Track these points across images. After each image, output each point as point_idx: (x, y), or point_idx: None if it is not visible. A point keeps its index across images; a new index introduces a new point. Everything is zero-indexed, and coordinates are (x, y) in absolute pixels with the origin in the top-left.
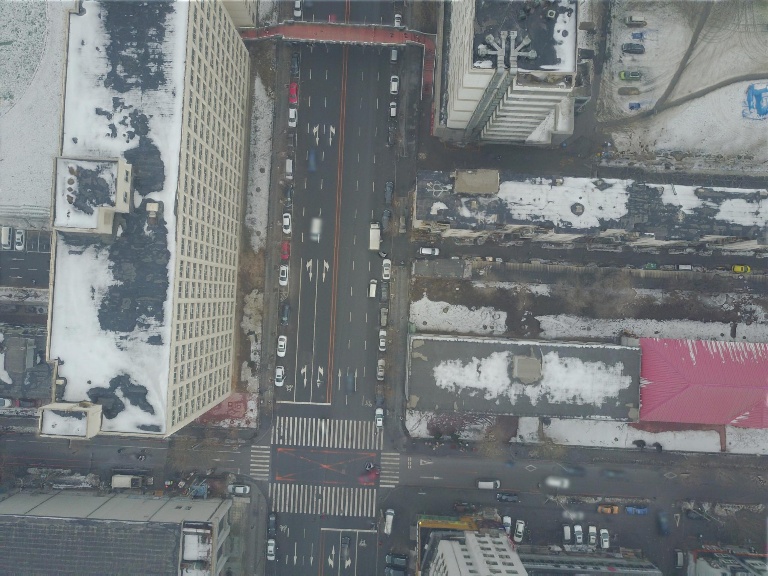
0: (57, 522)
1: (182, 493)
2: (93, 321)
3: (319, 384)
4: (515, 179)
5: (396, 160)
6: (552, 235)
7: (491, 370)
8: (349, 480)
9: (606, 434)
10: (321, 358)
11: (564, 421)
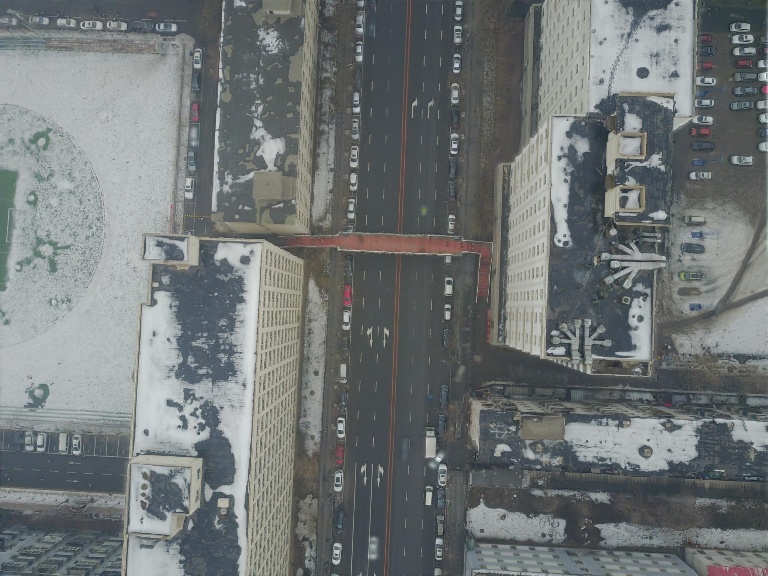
0: None
1: None
2: None
3: None
4: (580, 420)
5: (451, 362)
6: None
7: None
8: None
9: None
10: (376, 566)
11: None
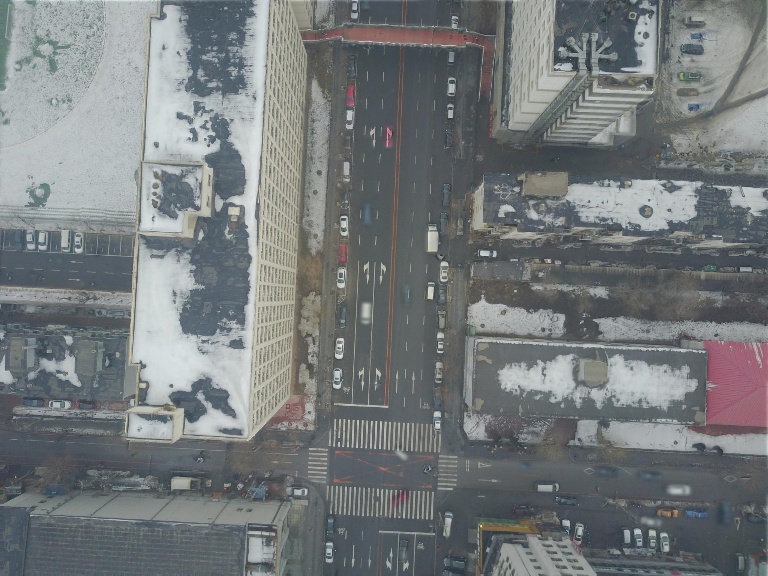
0: (123, 524)
1: (241, 495)
2: (175, 325)
3: (376, 386)
4: (583, 181)
5: (453, 162)
6: (616, 237)
7: (556, 373)
8: (407, 483)
9: (666, 437)
10: (379, 360)
11: (623, 424)
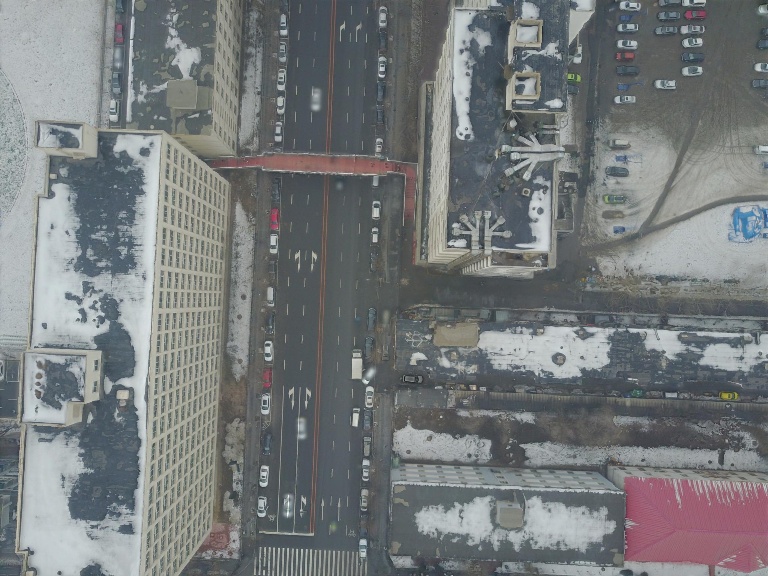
0: None
1: None
2: (63, 510)
3: (302, 514)
4: (495, 328)
5: (378, 286)
6: None
7: (473, 516)
8: None
9: None
10: (304, 488)
11: None
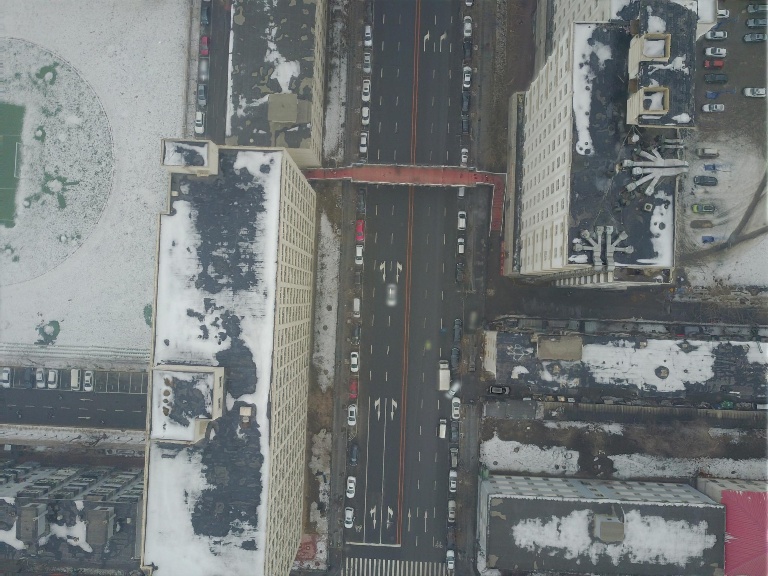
0: None
1: None
2: (187, 526)
3: (389, 525)
4: (597, 342)
5: (464, 296)
6: None
7: (571, 529)
8: None
9: None
10: (390, 499)
11: None
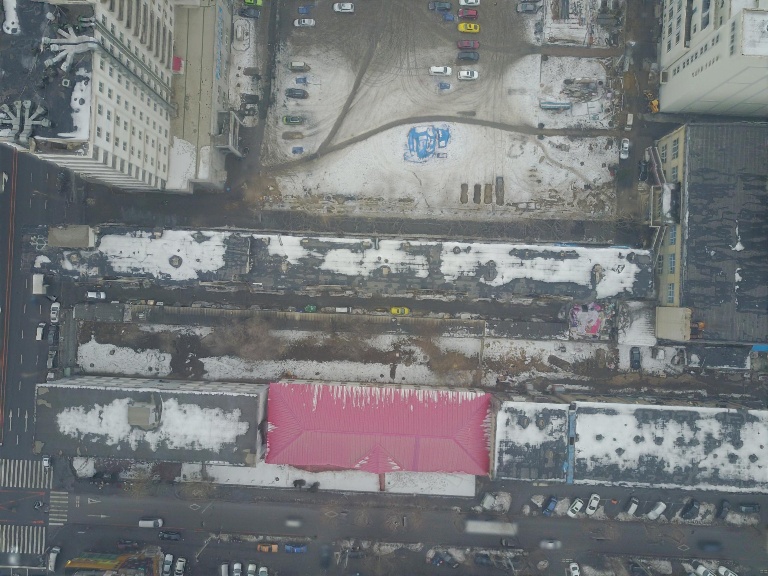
0: None
1: None
2: None
3: None
4: (116, 232)
5: (66, 205)
6: None
7: (112, 416)
8: (19, 518)
9: (264, 474)
10: None
11: None
